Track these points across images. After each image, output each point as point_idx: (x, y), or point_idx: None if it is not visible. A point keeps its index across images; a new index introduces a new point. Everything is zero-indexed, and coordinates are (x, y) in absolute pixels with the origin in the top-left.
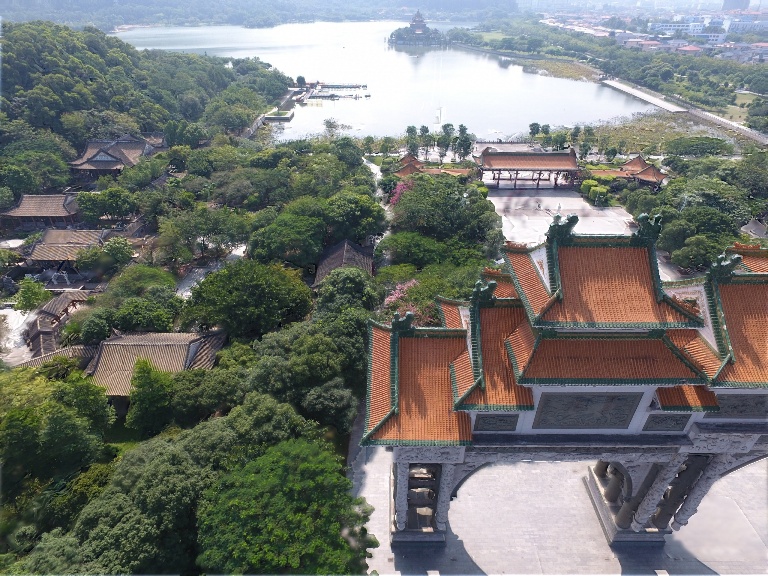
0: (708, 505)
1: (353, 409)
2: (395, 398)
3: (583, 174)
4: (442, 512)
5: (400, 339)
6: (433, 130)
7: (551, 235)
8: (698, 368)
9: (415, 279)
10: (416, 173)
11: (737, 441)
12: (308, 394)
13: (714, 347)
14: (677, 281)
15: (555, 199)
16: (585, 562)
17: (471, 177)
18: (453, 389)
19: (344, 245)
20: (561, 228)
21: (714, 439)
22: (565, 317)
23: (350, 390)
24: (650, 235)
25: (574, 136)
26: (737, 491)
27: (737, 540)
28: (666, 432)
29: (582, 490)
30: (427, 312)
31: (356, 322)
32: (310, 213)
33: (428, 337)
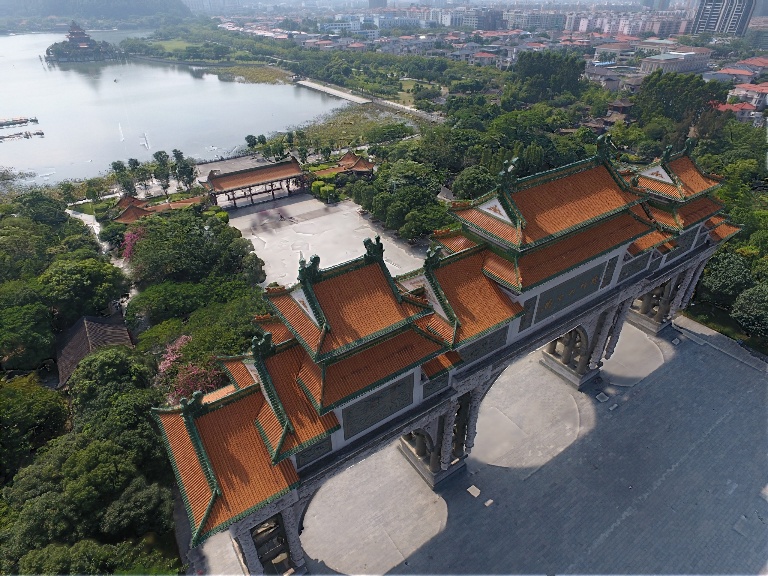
0: (482, 420)
1: (167, 502)
2: (212, 481)
3: (309, 177)
4: (296, 551)
5: (195, 421)
6: (144, 161)
7: (302, 278)
8: (441, 341)
9: (184, 332)
10: (143, 218)
11: (481, 375)
12: (105, 516)
13: (446, 318)
14: (407, 274)
15: (293, 206)
16: (421, 514)
17: (205, 204)
18: (266, 445)
19: (83, 324)
20: (309, 270)
21: (468, 381)
22: (338, 343)
23: (155, 484)
24: (377, 252)
25: (290, 141)
26: (495, 400)
27: (506, 435)
28: (438, 392)
29: (400, 457)
30: (211, 366)
31: (134, 409)
32: (20, 301)
33: (224, 406)
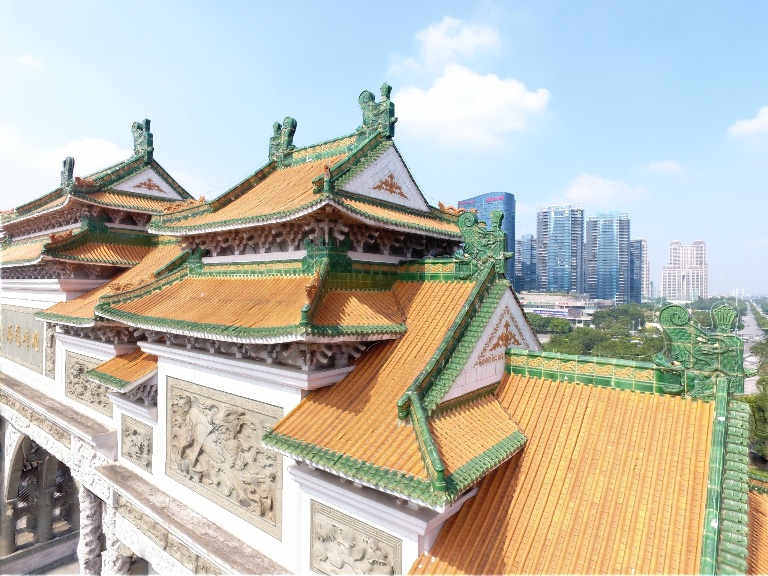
0: None
1: None
2: None
3: None
4: None
5: None
6: None
7: None
8: None
9: None
10: None
11: None
12: None
13: None
14: (160, 270)
15: None
16: None
17: None
18: None
19: None
20: None
21: None
22: None
23: None
24: None
25: None
26: None
27: None
28: None
29: None
30: None
31: None
32: None
33: None
